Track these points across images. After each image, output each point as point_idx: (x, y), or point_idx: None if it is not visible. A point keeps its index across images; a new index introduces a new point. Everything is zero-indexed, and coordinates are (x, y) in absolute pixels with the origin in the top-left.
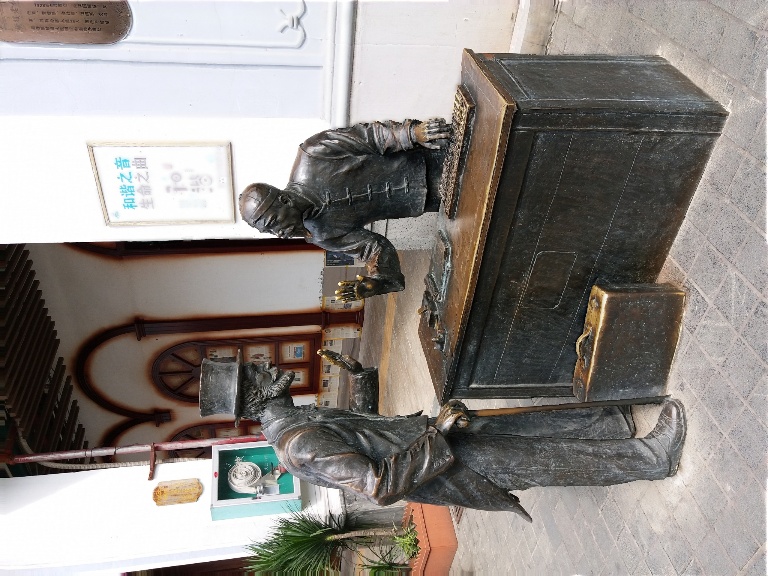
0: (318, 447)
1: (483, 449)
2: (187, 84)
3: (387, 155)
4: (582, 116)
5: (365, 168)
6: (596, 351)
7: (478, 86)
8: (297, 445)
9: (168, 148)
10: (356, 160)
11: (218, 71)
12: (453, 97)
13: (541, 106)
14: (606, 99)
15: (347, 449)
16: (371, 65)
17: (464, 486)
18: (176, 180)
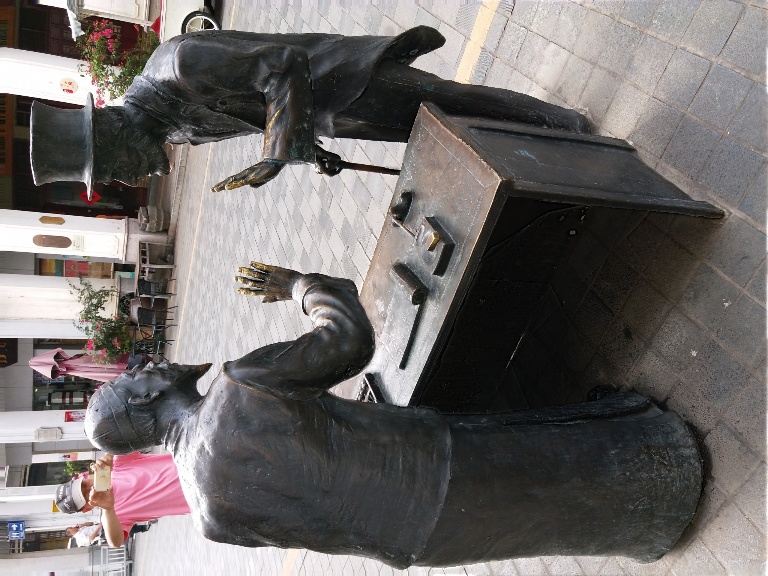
0: None
1: None
2: None
3: None
4: None
5: None
6: None
7: None
8: None
9: None
10: None
11: None
12: None
13: None
14: None
15: None
16: None
17: None
18: None
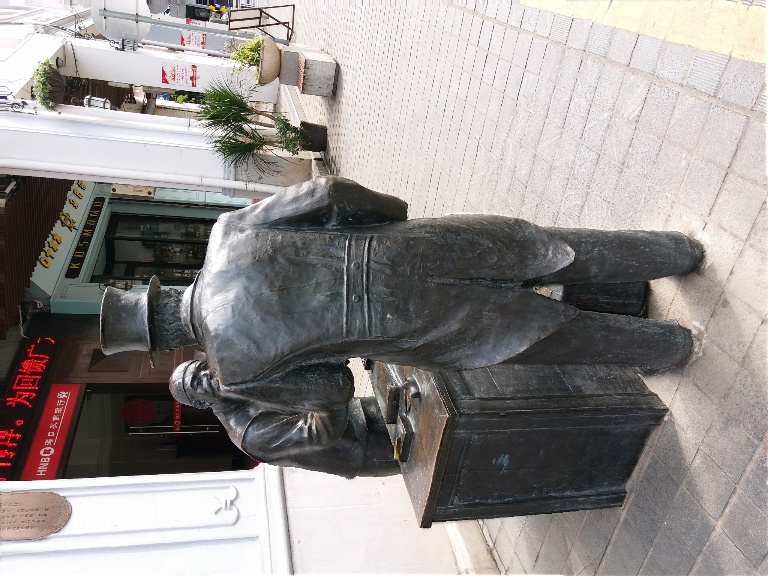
0: None
1: None
2: (109, 571)
3: None
4: None
5: None
6: None
7: None
8: None
9: None
10: None
11: (146, 555)
12: (402, 549)
13: None
14: None
15: None
16: (307, 527)
17: None
18: None
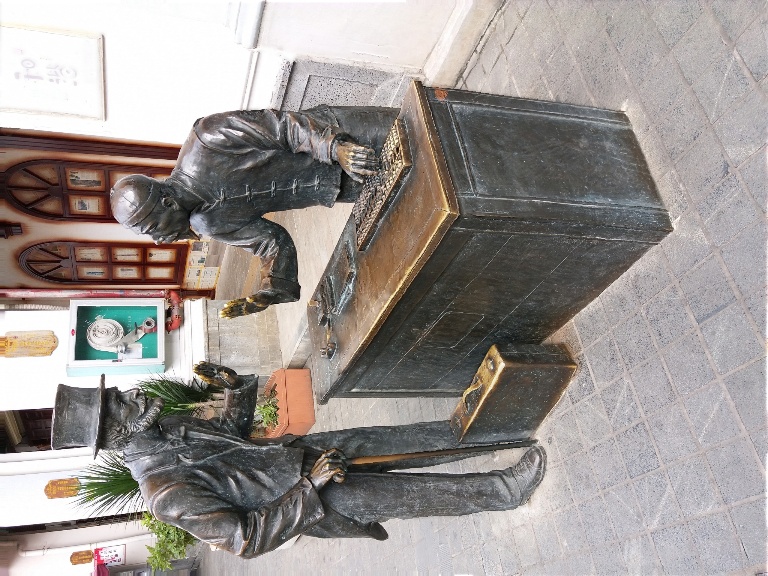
0: (186, 505)
1: (354, 493)
2: None
3: None
4: (527, 224)
5: (271, 164)
6: (481, 406)
7: (420, 147)
8: (163, 502)
9: (16, 29)
10: (262, 155)
11: None
12: (387, 27)
13: (486, 211)
14: (557, 202)
15: (217, 505)
16: None
17: (330, 527)
18: (28, 66)
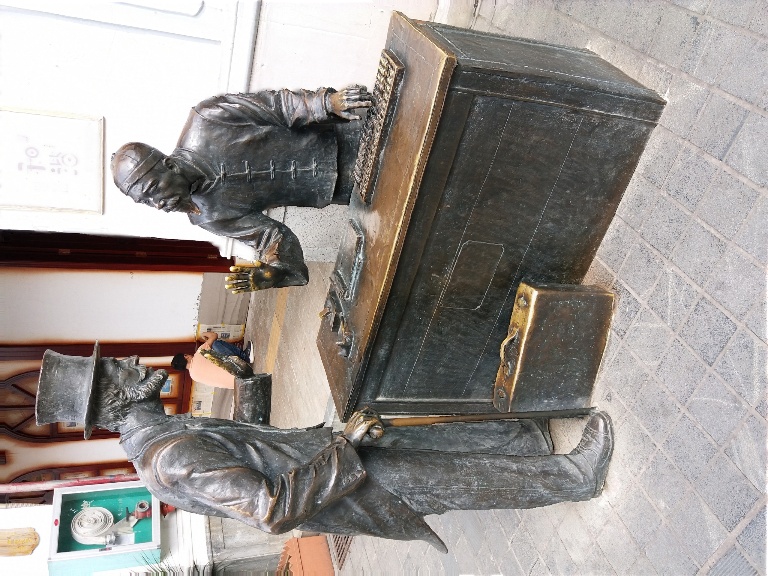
0: (197, 460)
1: (398, 465)
2: (54, 40)
3: (295, 129)
4: (524, 83)
5: (269, 141)
6: (523, 355)
7: (409, 45)
8: (169, 457)
9: (24, 115)
10: (259, 130)
11: (95, 30)
12: None
13: (482, 66)
14: (548, 70)
15: (234, 462)
16: (276, 47)
17: (375, 509)
18: (31, 155)
